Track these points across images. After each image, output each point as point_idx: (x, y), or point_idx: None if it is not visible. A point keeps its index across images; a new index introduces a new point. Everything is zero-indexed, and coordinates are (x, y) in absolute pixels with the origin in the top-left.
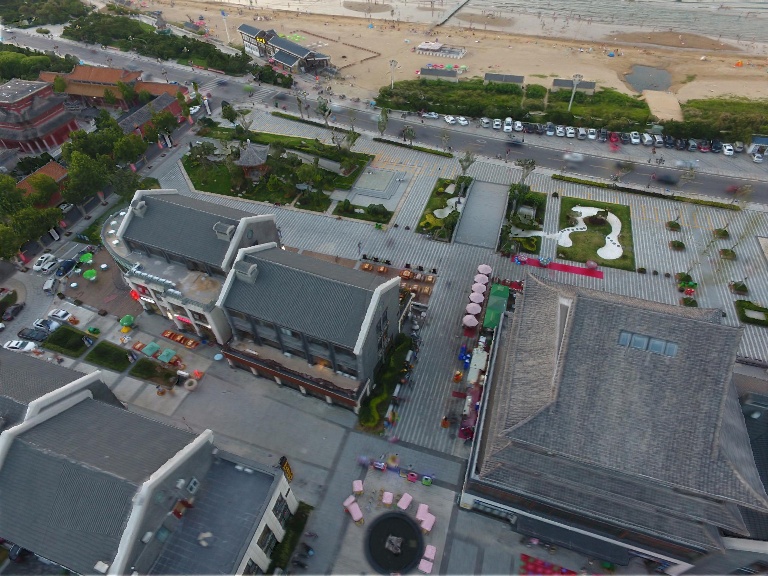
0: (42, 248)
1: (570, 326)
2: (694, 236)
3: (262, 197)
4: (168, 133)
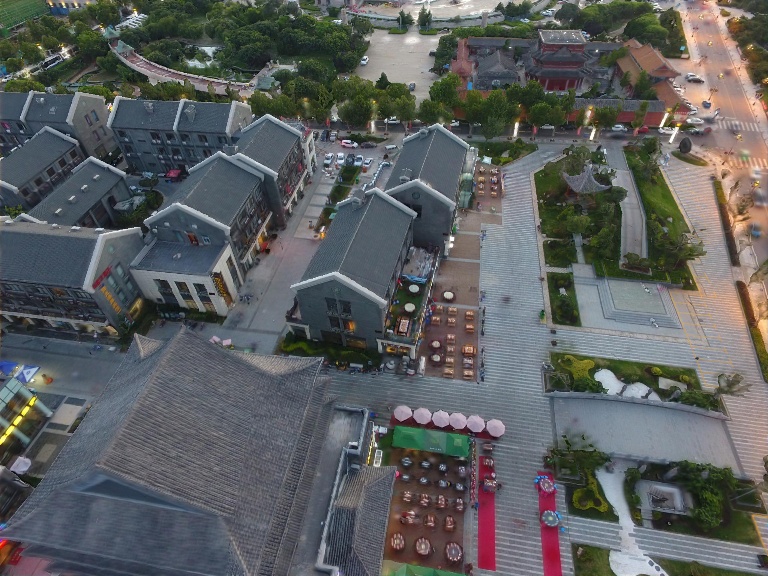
0: None
1: None
2: None
3: (546, 215)
4: (595, 127)
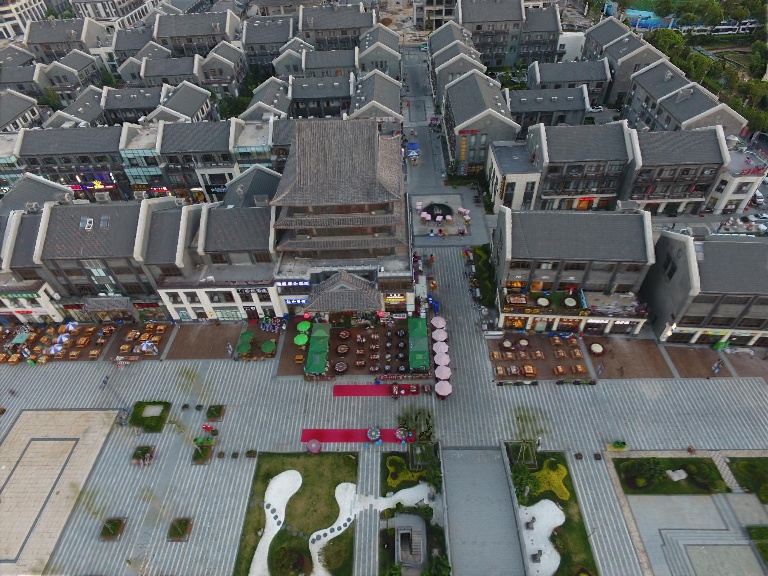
0: None
1: None
2: (139, 570)
3: None
4: None
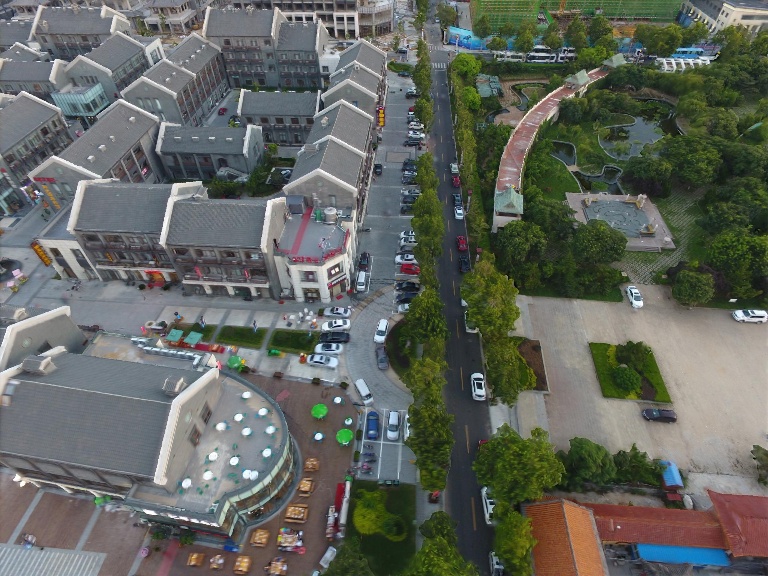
0: None
1: None
2: None
3: None
4: None
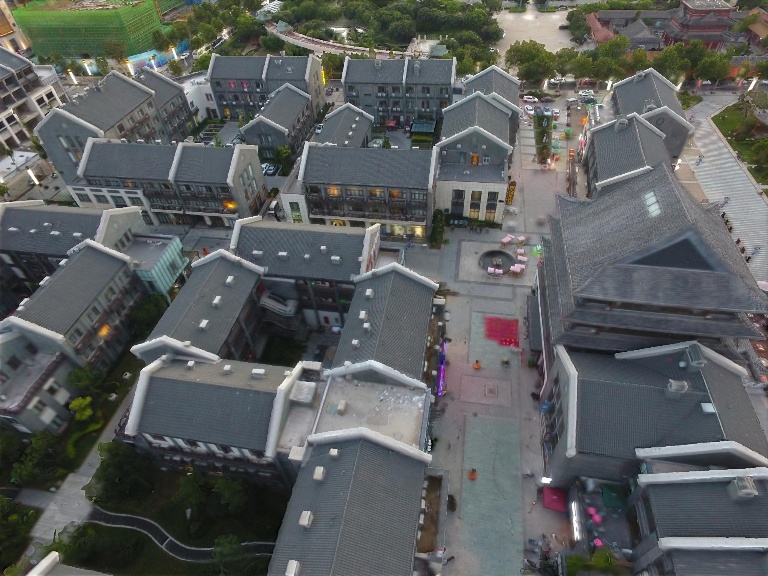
0: (596, 88)
1: None
2: None
3: (739, 148)
4: (757, 78)
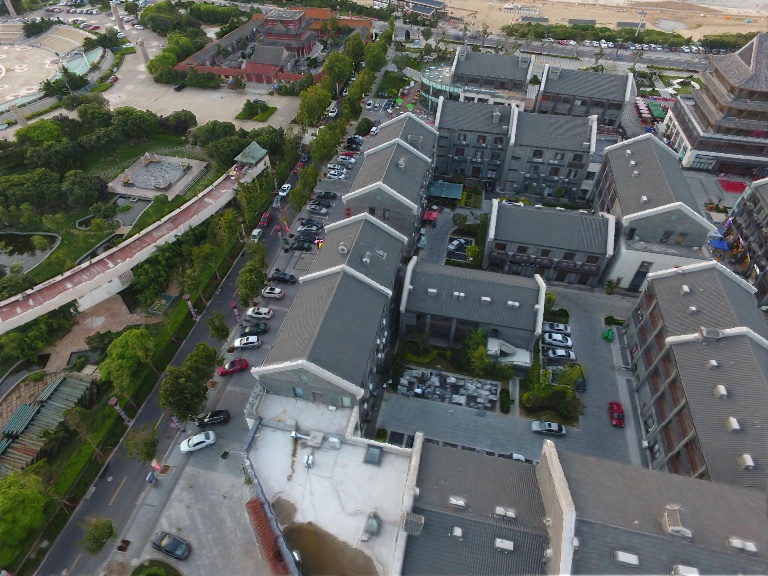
0: None
1: (758, 45)
2: None
3: None
4: (389, 45)
